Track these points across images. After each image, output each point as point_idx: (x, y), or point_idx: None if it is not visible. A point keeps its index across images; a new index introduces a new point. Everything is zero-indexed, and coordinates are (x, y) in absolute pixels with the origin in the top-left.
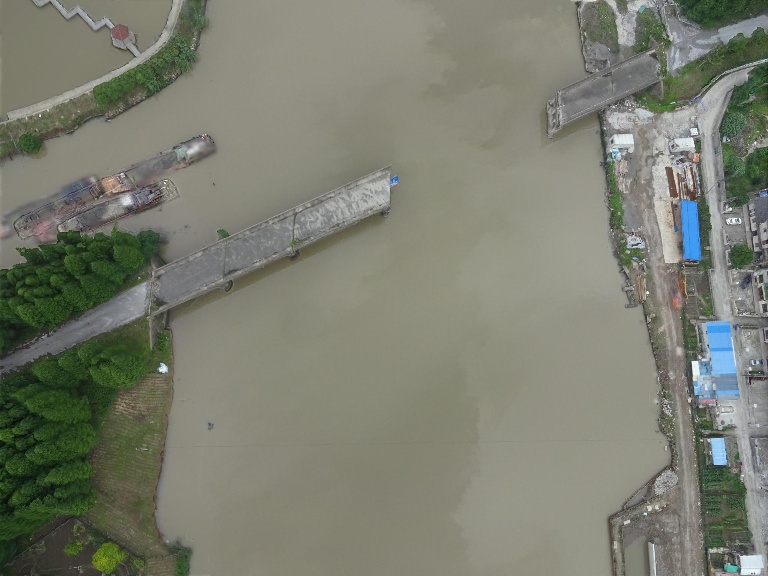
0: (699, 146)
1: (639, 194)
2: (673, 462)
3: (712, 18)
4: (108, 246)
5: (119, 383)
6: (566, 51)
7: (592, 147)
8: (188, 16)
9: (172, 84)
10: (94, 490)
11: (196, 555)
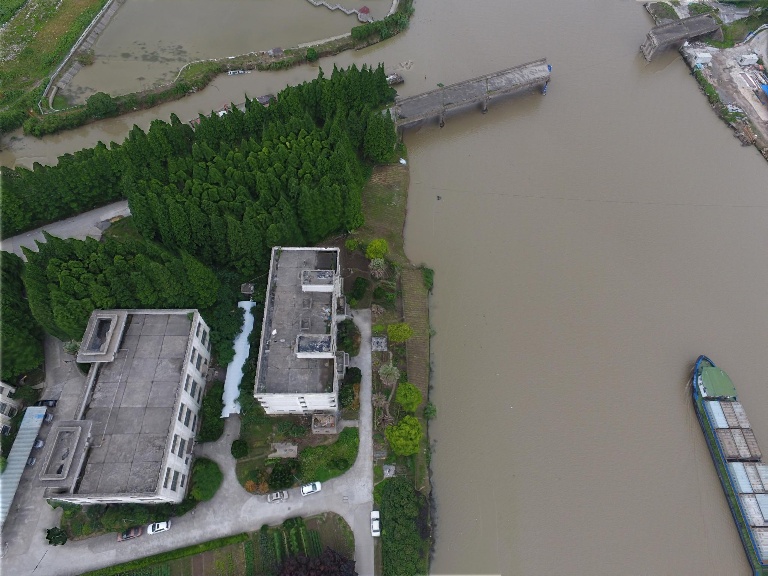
0: (761, 61)
1: (726, 86)
2: None
3: (743, 2)
4: None
5: (380, 151)
6: None
7: (680, 68)
8: (404, 4)
9: (394, 36)
10: (363, 215)
11: (437, 276)
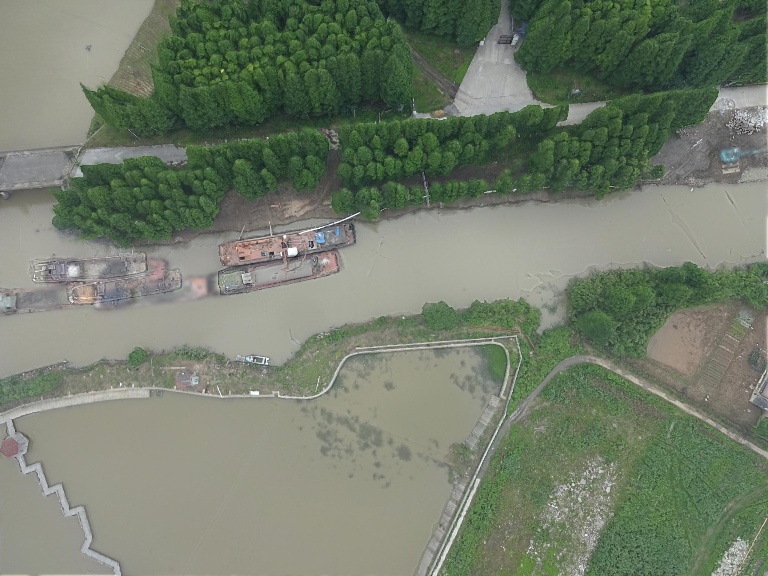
0: None
1: None
2: None
3: None
4: None
5: None
6: None
7: None
8: None
9: None
10: None
11: None
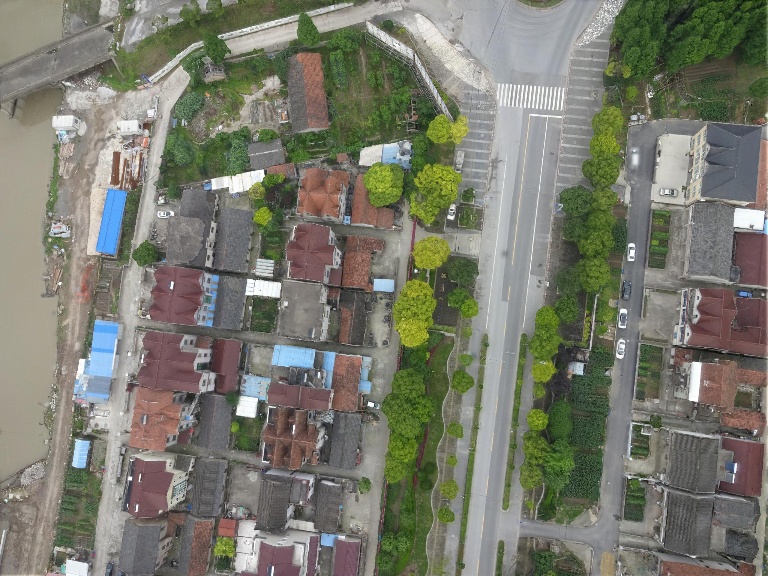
0: (150, 129)
1: (79, 180)
2: (46, 456)
3: None
4: None
5: None
6: (48, 25)
7: None
8: None
9: None
10: None
11: None
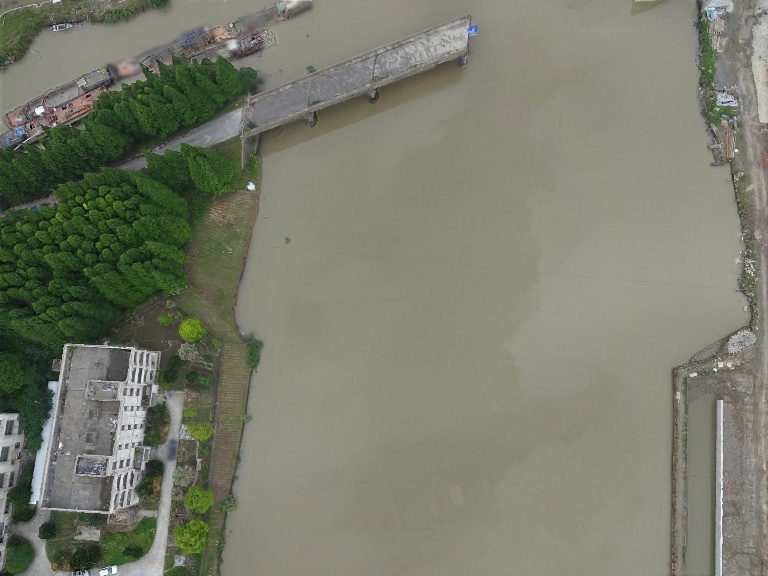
0: None
1: (735, 53)
2: (752, 322)
3: None
4: (212, 70)
5: (213, 187)
6: None
7: (686, 9)
8: None
9: None
10: (186, 276)
11: (266, 349)
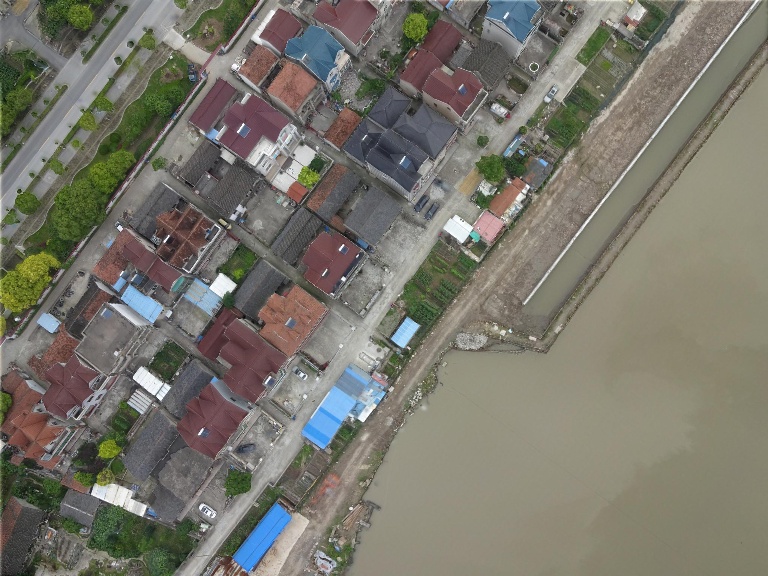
0: None
1: None
2: (449, 350)
3: None
4: None
5: None
6: None
7: None
8: None
9: None
10: None
11: None
